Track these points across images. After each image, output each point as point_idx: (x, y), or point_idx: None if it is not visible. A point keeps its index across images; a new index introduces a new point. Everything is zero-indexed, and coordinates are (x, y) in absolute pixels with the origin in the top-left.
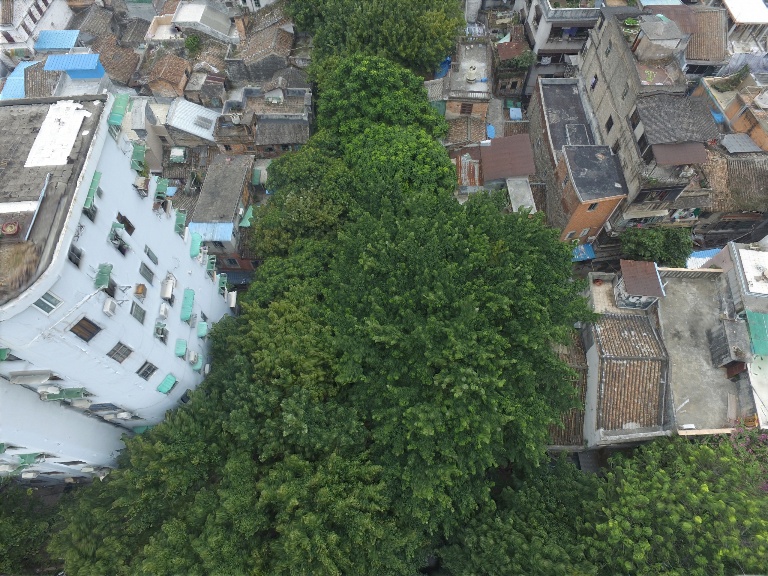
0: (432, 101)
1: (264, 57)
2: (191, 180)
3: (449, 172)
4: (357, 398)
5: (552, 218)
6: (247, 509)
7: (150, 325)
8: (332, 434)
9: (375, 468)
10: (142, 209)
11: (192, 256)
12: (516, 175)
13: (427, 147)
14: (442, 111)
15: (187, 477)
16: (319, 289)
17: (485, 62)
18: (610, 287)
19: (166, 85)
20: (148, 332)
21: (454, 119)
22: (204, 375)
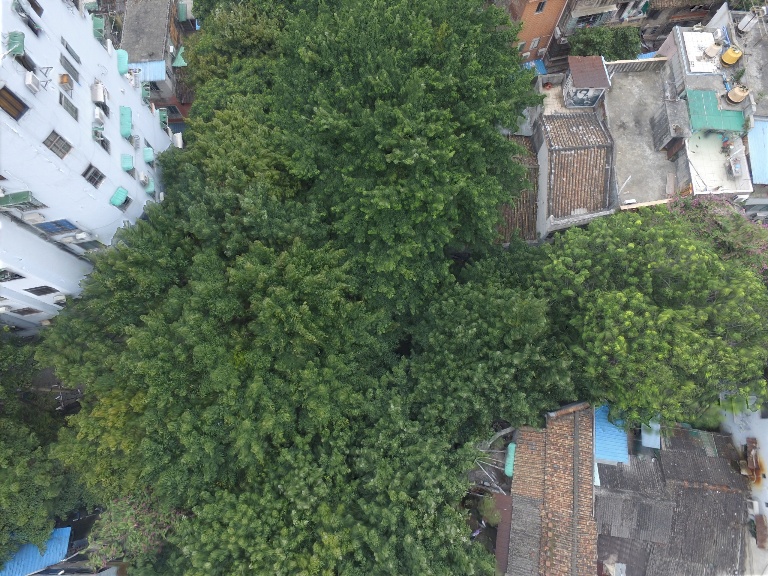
0: None
1: None
2: (111, 27)
3: None
4: (315, 198)
5: None
6: (220, 294)
7: (86, 126)
8: (293, 223)
9: (339, 251)
10: None
11: (121, 73)
12: None
13: None
14: None
15: (157, 278)
16: (264, 103)
17: None
18: (559, 89)
19: None
20: (85, 132)
21: None
22: None
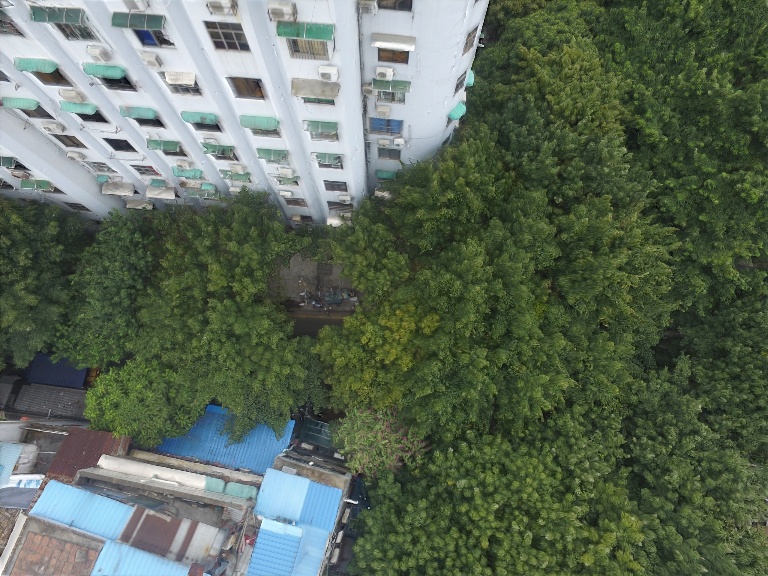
0: None
1: None
2: None
3: None
4: None
5: None
6: (549, 240)
7: None
8: (635, 186)
9: (670, 229)
10: None
11: None
12: None
13: None
14: None
15: None
16: None
17: None
18: None
19: None
20: None
21: None
22: (454, 128)
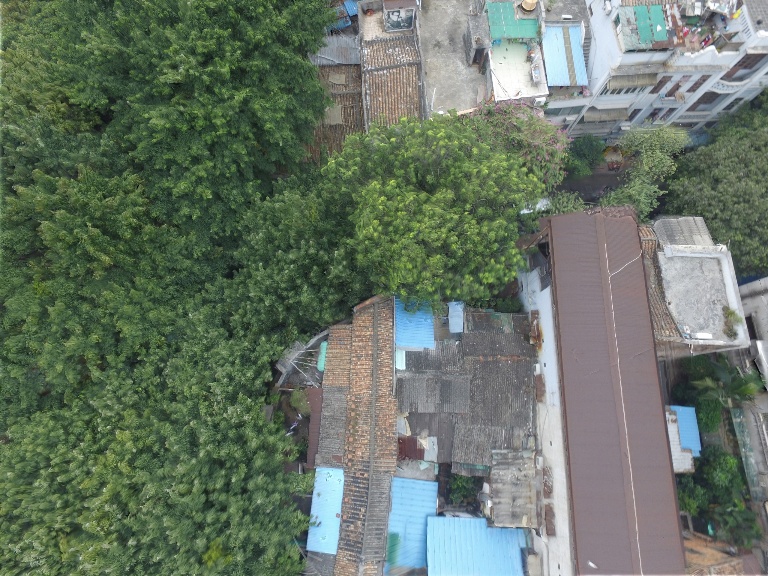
0: None
1: None
2: None
3: None
4: (113, 130)
5: None
6: (7, 226)
7: None
8: None
9: (132, 177)
10: None
11: None
12: None
13: None
14: None
15: None
16: None
17: None
18: (380, 15)
19: None
20: None
21: None
22: None
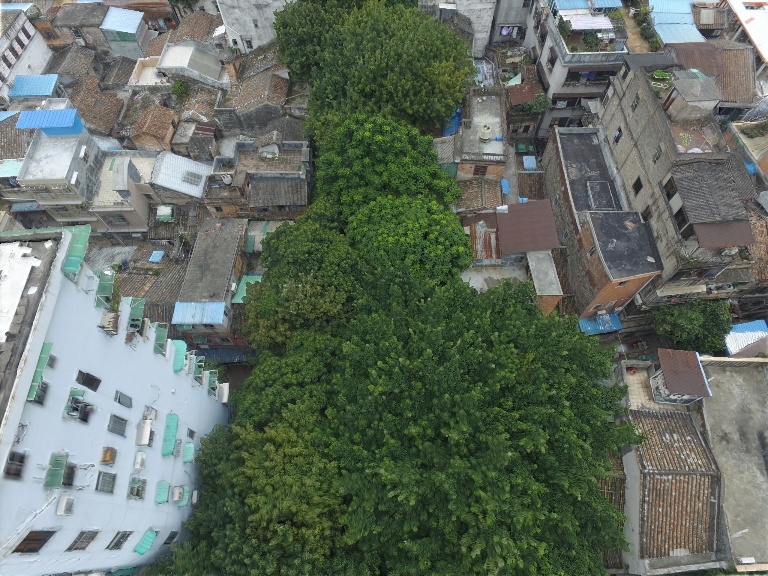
0: (442, 163)
1: (257, 107)
2: (179, 243)
3: (465, 251)
4: (369, 547)
5: (575, 287)
6: None
7: (122, 487)
8: None
9: None
10: (111, 349)
11: (176, 371)
12: (538, 249)
13: (440, 225)
14: (453, 172)
15: None
16: (322, 401)
17: (499, 117)
18: (645, 376)
19: (151, 139)
20: (120, 498)
21: (466, 180)
22: (191, 505)
